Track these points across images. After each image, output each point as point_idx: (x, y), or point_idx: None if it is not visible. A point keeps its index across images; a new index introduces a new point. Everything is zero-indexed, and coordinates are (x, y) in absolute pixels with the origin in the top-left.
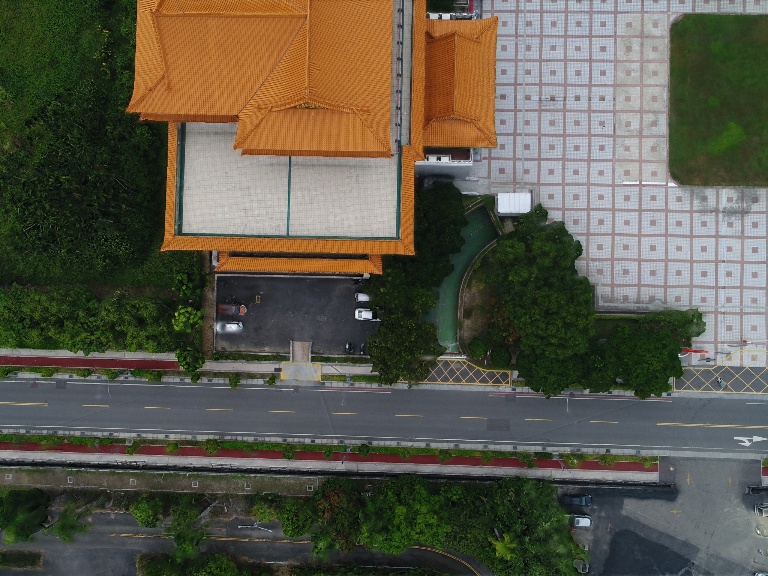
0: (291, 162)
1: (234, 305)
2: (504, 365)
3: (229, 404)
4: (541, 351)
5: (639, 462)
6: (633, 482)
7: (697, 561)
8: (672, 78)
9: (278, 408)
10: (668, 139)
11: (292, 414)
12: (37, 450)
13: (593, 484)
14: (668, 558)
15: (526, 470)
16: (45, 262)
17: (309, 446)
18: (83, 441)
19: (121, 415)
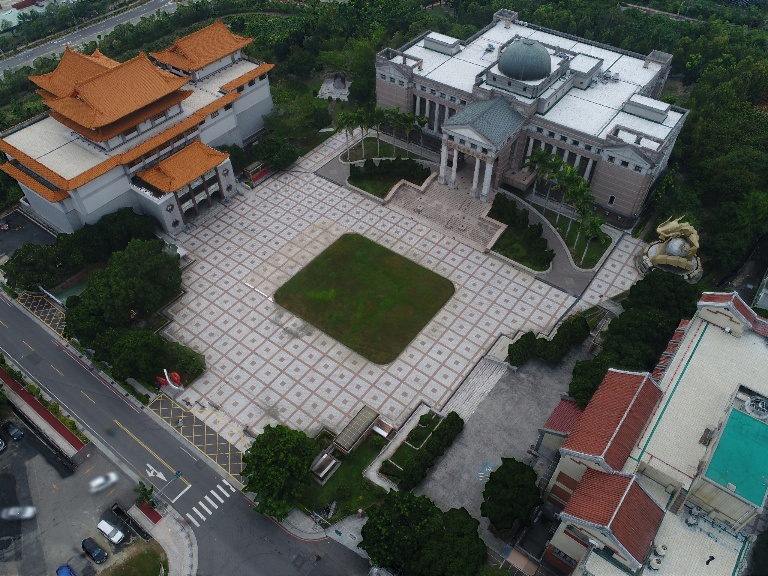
0: (73, 141)
1: None
2: None
3: None
4: None
5: (76, 436)
6: (57, 447)
7: (24, 538)
8: (322, 254)
9: None
10: (291, 278)
11: None
12: None
13: (35, 431)
14: (11, 519)
15: (13, 394)
16: None
17: None
18: None
19: None
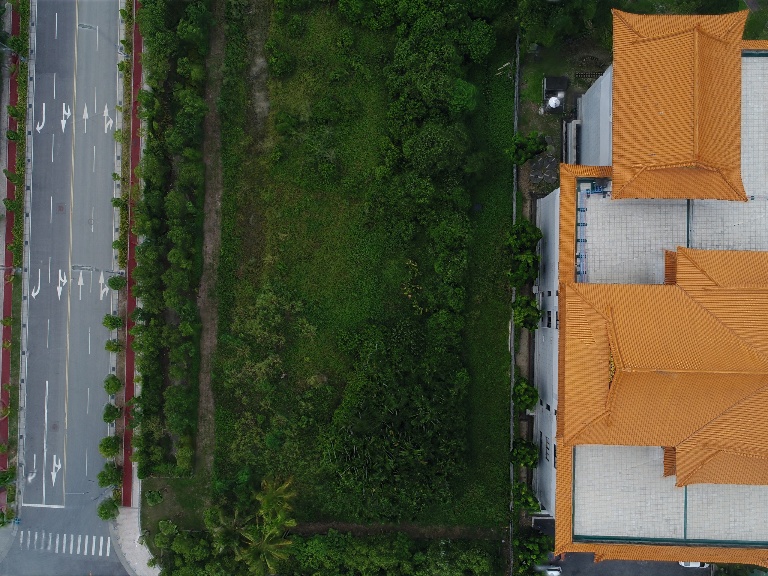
0: None
1: None
2: None
3: None
4: None
5: None
6: None
7: None
8: None
9: None
10: None
11: None
12: None
13: None
14: None
15: None
16: (353, 500)
17: None
18: None
19: None
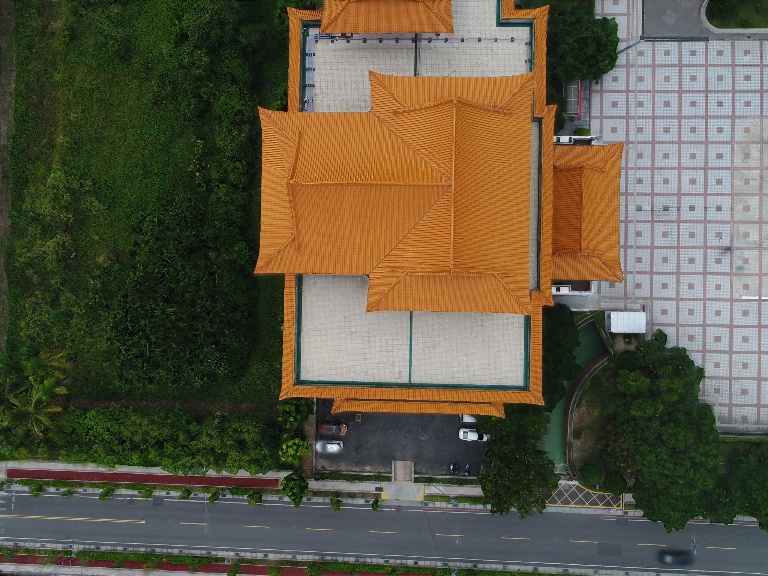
0: None
1: (335, 424)
2: (619, 493)
3: (329, 524)
4: (664, 487)
5: None
6: None
7: None
8: None
9: (380, 529)
10: None
11: (394, 535)
12: (135, 568)
13: None
14: None
15: None
16: None
17: (413, 569)
18: (182, 560)
19: (219, 533)
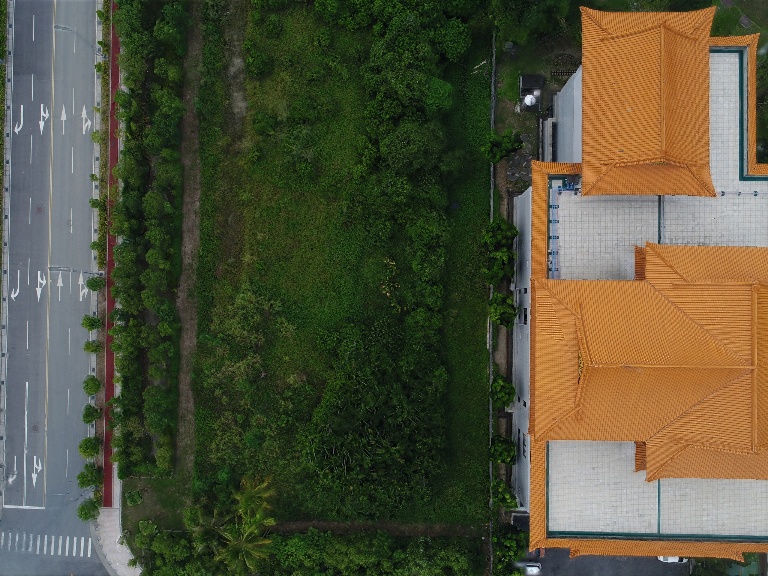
0: None
1: None
2: None
3: None
4: None
5: None
6: None
7: None
8: None
9: None
10: None
11: None
12: None
13: None
14: None
15: None
16: (333, 498)
17: None
18: None
19: None
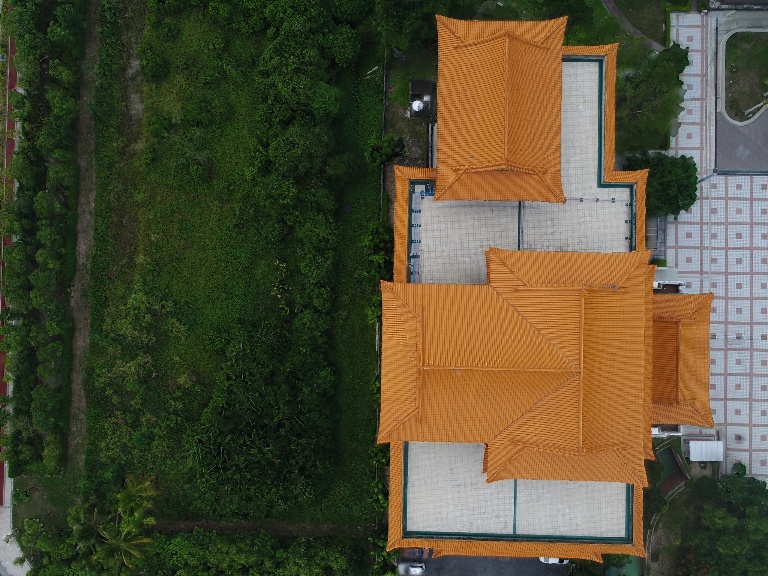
0: None
1: None
2: None
3: None
4: None
5: None
6: None
7: None
8: None
9: None
10: None
11: None
12: None
13: None
14: None
15: None
16: None
17: None
18: None
19: None
